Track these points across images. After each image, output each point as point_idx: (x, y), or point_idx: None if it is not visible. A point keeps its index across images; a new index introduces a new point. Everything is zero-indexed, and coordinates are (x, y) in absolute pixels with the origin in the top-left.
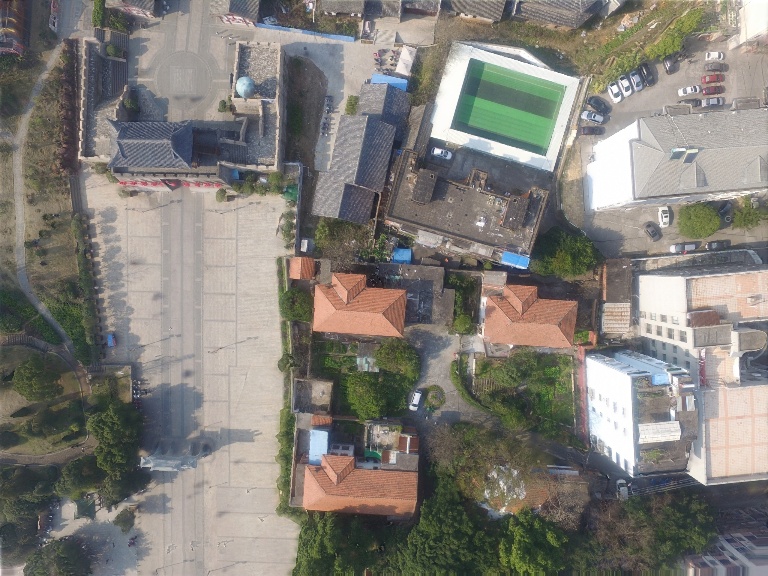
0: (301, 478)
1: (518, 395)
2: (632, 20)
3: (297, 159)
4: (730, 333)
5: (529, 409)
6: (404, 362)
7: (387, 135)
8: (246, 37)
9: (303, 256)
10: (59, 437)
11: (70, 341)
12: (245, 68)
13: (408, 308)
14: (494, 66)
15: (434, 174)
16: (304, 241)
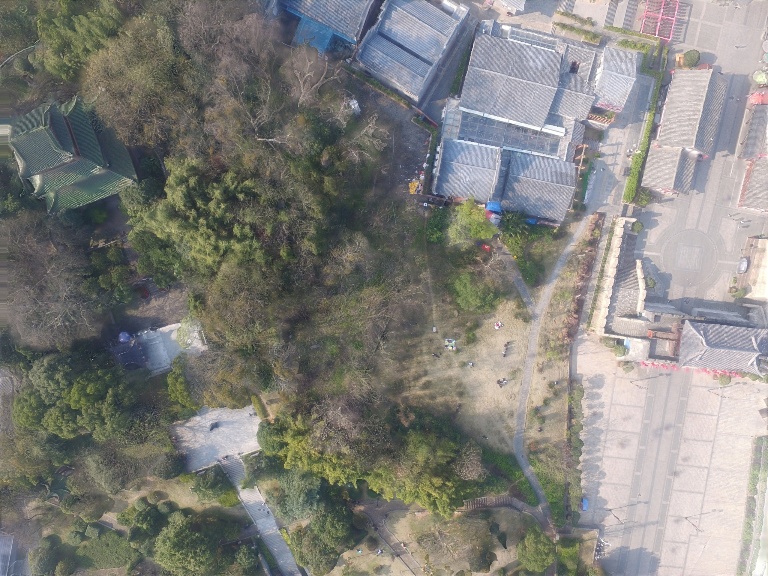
0: None
1: None
2: None
3: None
4: None
5: None
6: None
7: None
8: (757, 222)
9: None
10: None
11: (546, 503)
12: None
13: None
14: None
15: None
16: None
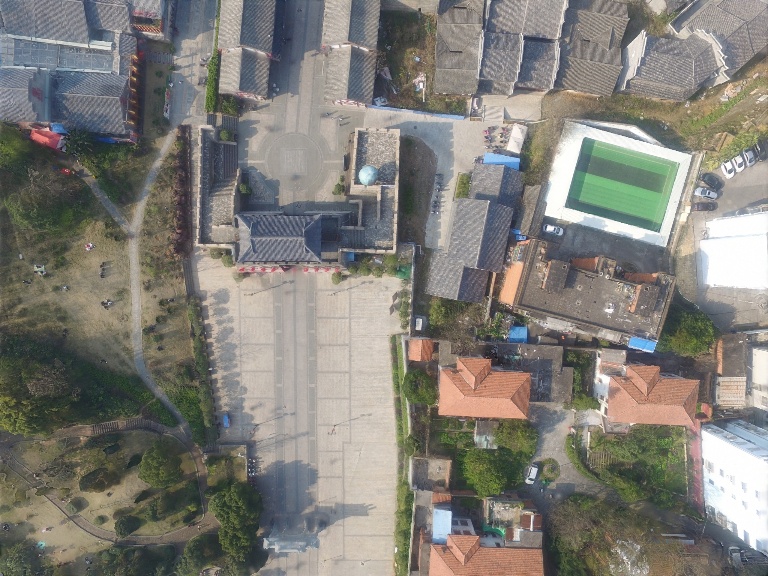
0: (426, 557)
1: None
2: (735, 90)
3: (409, 238)
4: None
5: (642, 479)
6: (526, 441)
7: (505, 217)
8: (356, 118)
9: (417, 334)
10: (176, 517)
11: (186, 423)
12: (363, 153)
13: None
14: (607, 144)
15: (567, 265)
16: (419, 320)
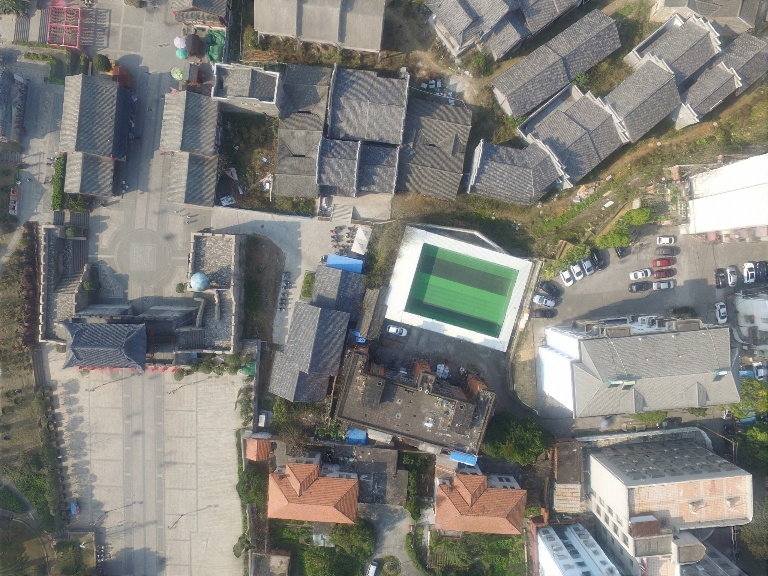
0: None
1: (472, 565)
2: (588, 191)
3: (255, 334)
4: (670, 542)
5: None
6: (358, 543)
7: (341, 322)
8: (204, 216)
9: (261, 430)
10: None
11: (35, 509)
12: (201, 256)
13: (362, 489)
14: (448, 249)
15: (382, 382)
16: (262, 416)
